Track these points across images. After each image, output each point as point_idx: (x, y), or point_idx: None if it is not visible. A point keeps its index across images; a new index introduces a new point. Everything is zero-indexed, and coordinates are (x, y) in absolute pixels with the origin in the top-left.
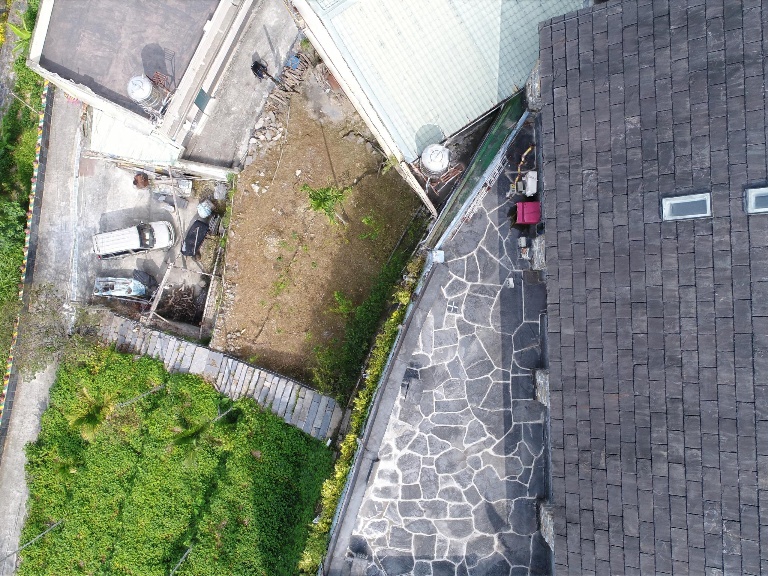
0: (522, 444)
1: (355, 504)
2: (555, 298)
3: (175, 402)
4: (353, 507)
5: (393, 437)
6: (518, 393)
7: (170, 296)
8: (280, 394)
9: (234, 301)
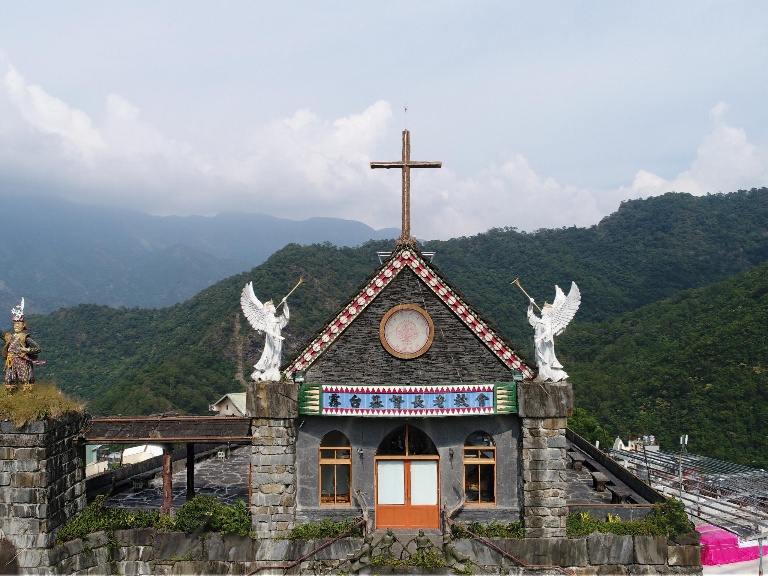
0: None
1: (157, 469)
2: None
3: None
4: None
5: None
6: None
7: None
8: None
9: None
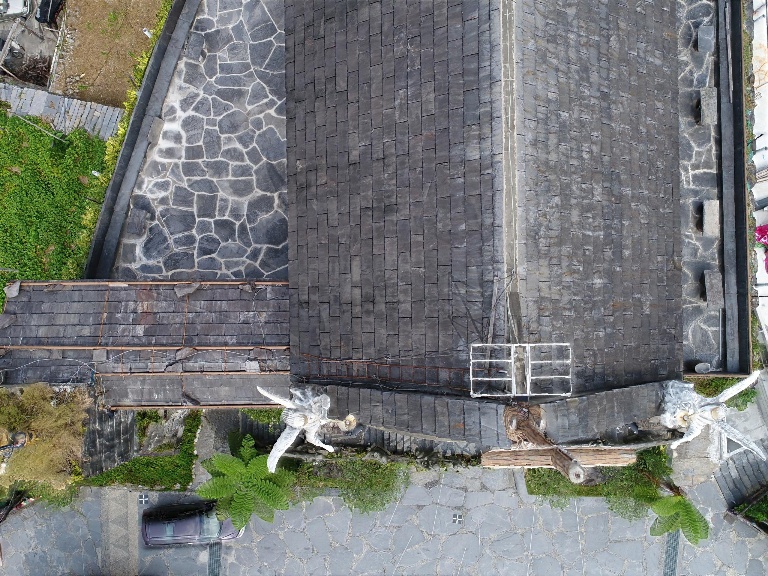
0: None
1: (136, 159)
2: None
3: (12, 141)
4: (134, 162)
5: (178, 99)
6: None
7: (24, 63)
8: (108, 121)
9: (74, 46)
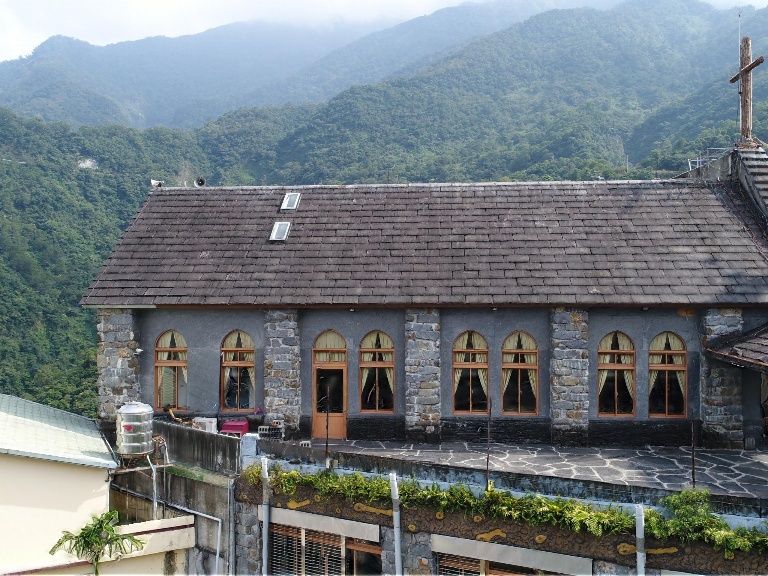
0: (492, 449)
1: None
2: (328, 298)
3: None
4: None
5: None
6: (433, 448)
7: None
8: None
9: None
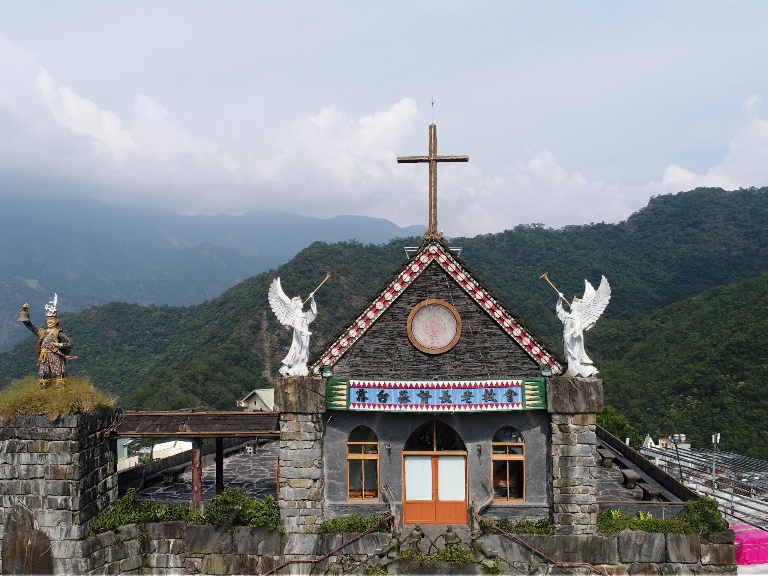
0: None
1: None
2: None
3: None
4: (185, 464)
5: None
6: None
7: None
8: None
9: None
